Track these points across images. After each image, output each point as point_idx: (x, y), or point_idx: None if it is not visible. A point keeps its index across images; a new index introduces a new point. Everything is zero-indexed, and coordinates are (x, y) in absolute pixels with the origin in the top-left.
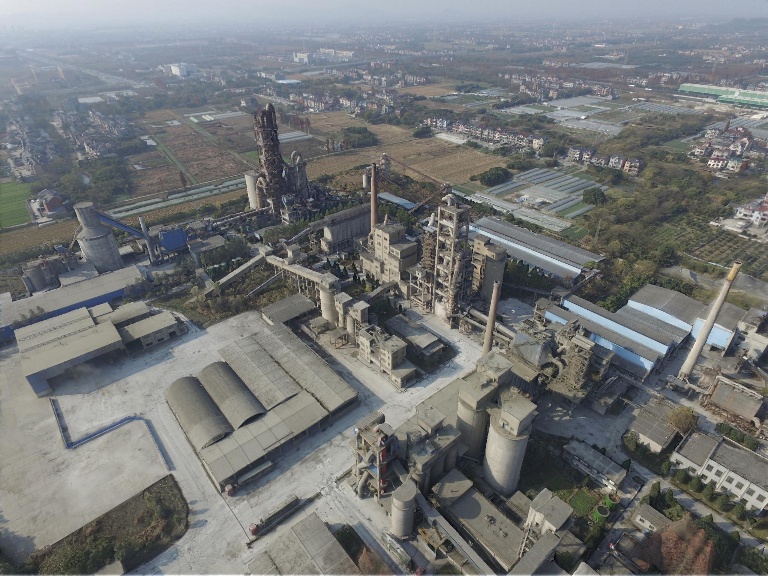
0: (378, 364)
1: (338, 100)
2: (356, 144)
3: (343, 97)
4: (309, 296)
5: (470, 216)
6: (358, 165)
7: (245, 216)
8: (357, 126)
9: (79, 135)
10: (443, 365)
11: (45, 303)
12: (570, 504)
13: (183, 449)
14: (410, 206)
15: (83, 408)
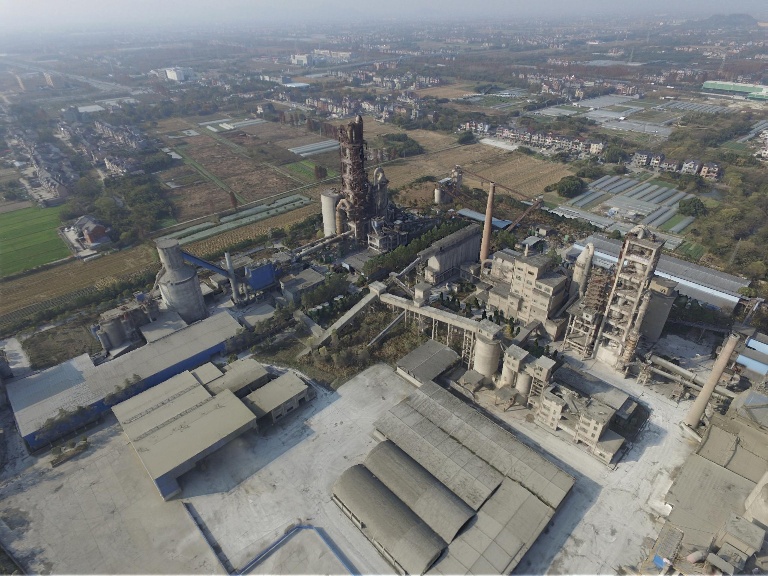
0: (571, 433)
1: (359, 104)
2: (404, 153)
3: (365, 101)
4: (448, 344)
5: (570, 234)
6: (414, 177)
7: (328, 243)
8: (394, 133)
9: (96, 150)
10: (642, 429)
11: (136, 367)
12: None
13: (383, 571)
14: (501, 224)
15: (229, 514)
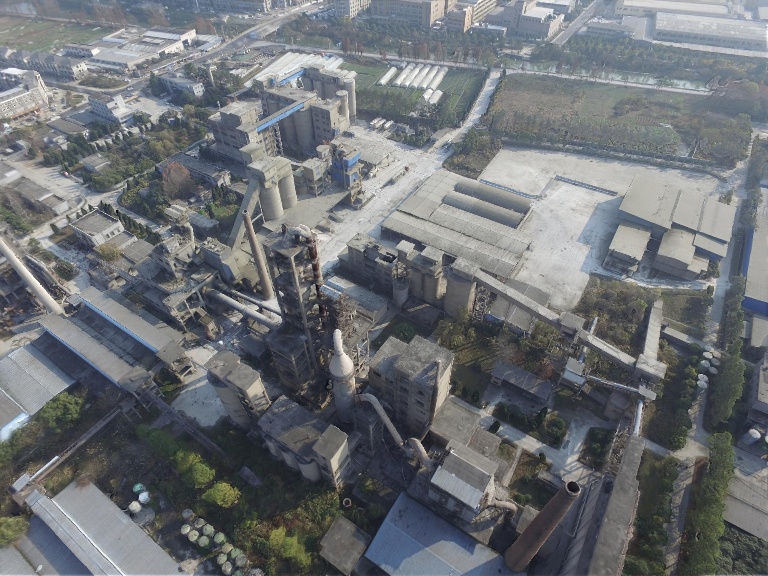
0: None
1: None
2: None
3: None
4: None
5: None
6: None
7: None
8: None
9: None
10: None
11: None
12: (226, 210)
13: None
14: None
15: (585, 195)
